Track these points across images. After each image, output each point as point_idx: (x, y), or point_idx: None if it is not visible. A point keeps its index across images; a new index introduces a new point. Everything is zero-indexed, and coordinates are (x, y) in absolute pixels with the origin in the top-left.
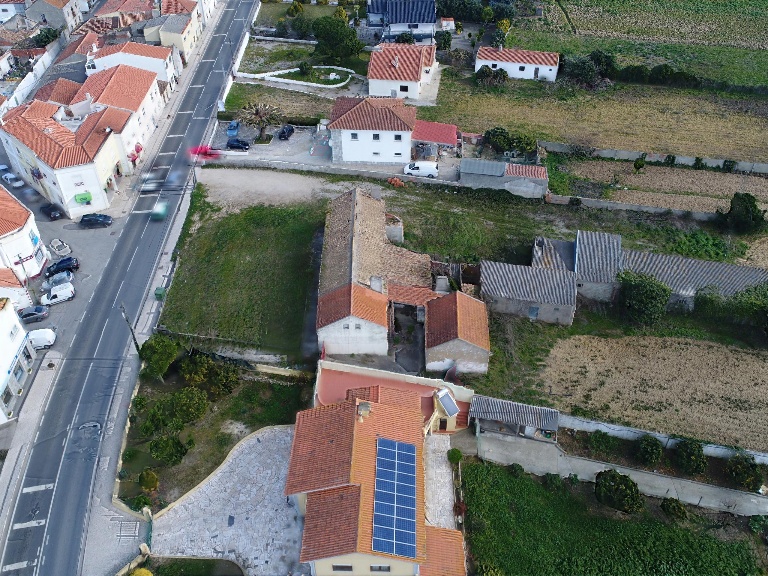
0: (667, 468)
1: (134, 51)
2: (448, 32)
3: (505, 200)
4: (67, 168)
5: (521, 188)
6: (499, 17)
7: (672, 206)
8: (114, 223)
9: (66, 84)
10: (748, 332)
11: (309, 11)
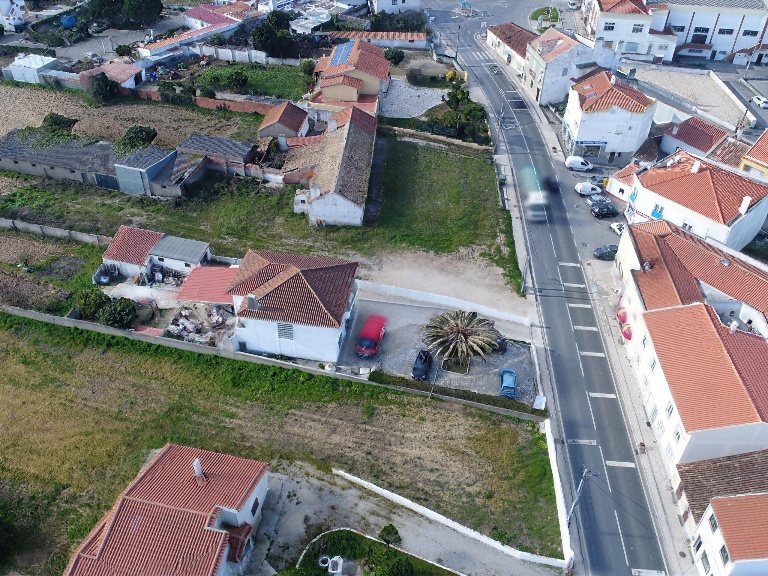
0: None
1: None
2: None
3: None
4: None
5: None
6: None
7: None
8: None
9: None
10: None
11: None
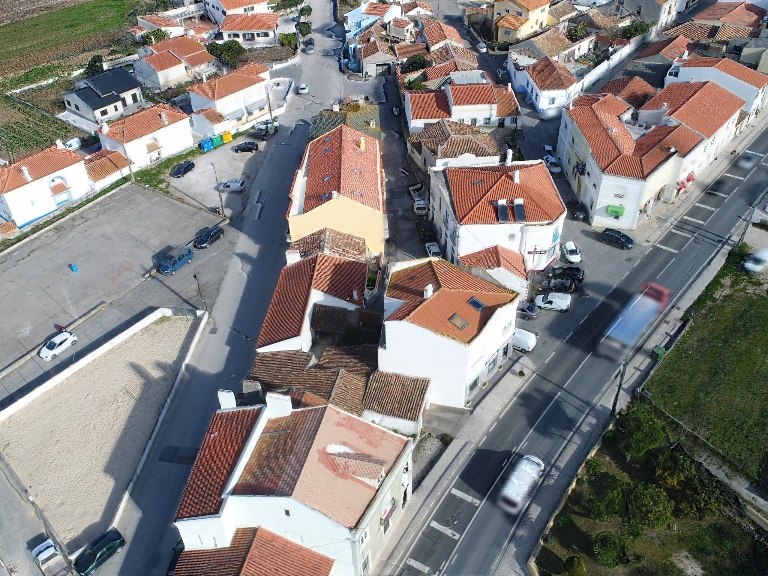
0: None
1: (728, 70)
2: None
3: None
4: (616, 176)
5: None
6: None
7: None
8: (633, 249)
9: (640, 84)
10: None
11: None
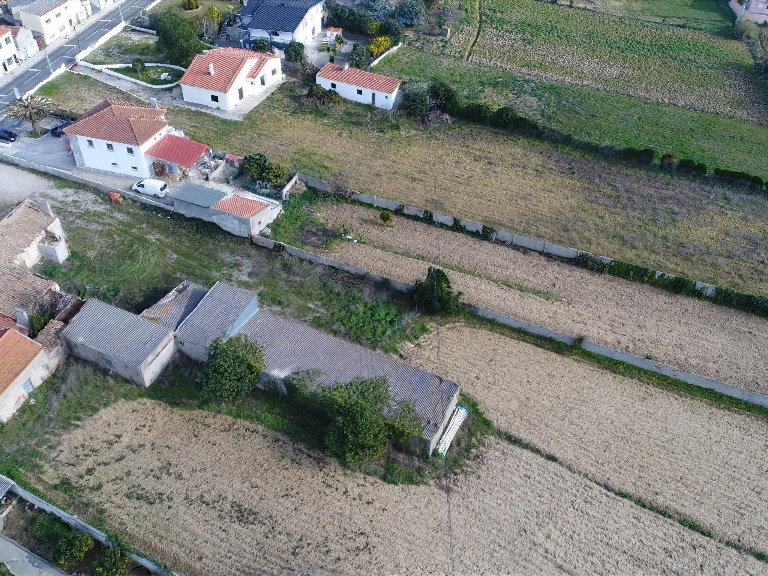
0: None
1: None
2: (299, 44)
3: (211, 234)
4: None
5: (228, 223)
6: (386, 33)
7: (388, 269)
8: None
9: None
10: None
11: (207, 6)
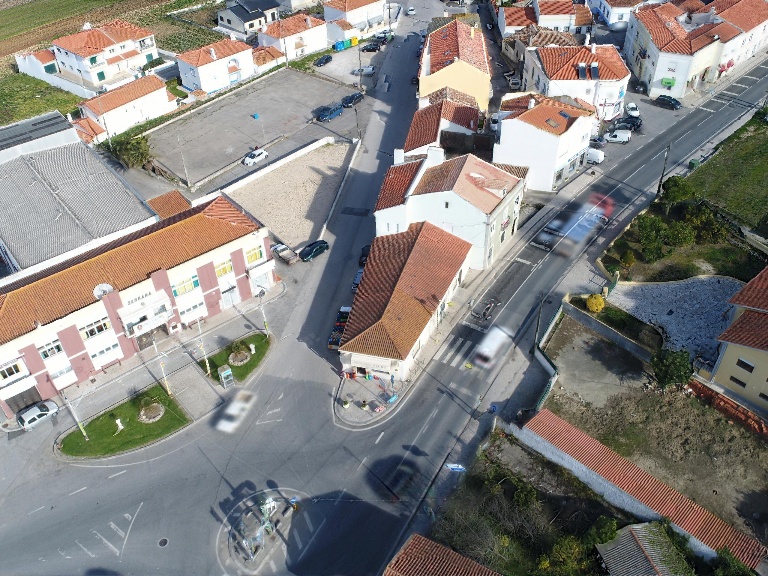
0: None
1: None
2: None
3: None
4: (671, 53)
5: None
6: None
7: None
8: (681, 109)
9: (695, 2)
10: None
11: None
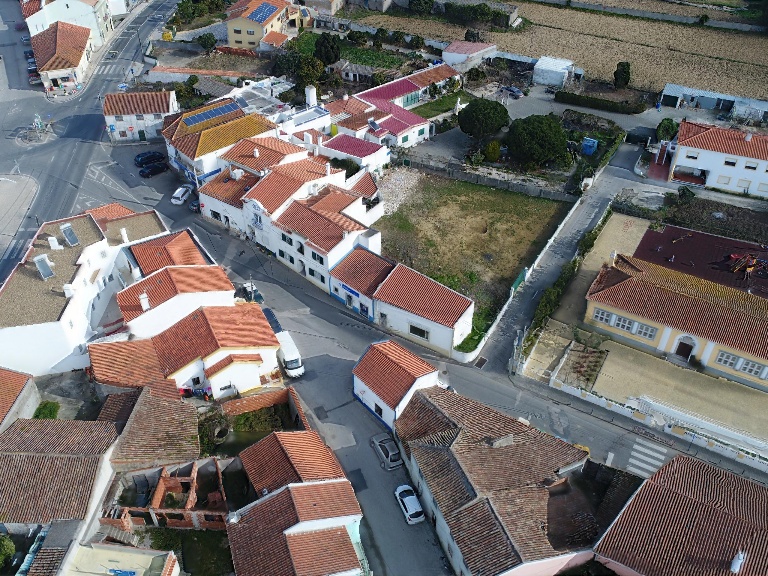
0: (389, 43)
1: None
2: None
3: None
4: None
5: None
6: None
7: None
8: None
9: None
10: (467, 22)
11: None
